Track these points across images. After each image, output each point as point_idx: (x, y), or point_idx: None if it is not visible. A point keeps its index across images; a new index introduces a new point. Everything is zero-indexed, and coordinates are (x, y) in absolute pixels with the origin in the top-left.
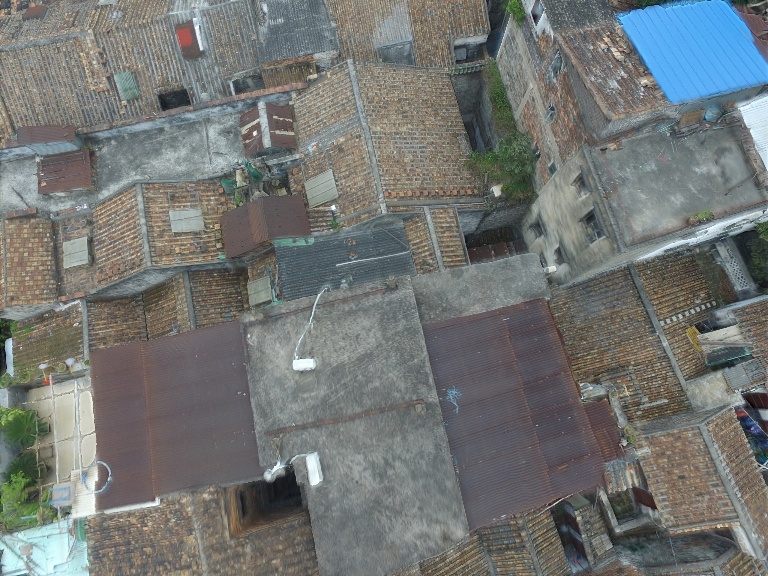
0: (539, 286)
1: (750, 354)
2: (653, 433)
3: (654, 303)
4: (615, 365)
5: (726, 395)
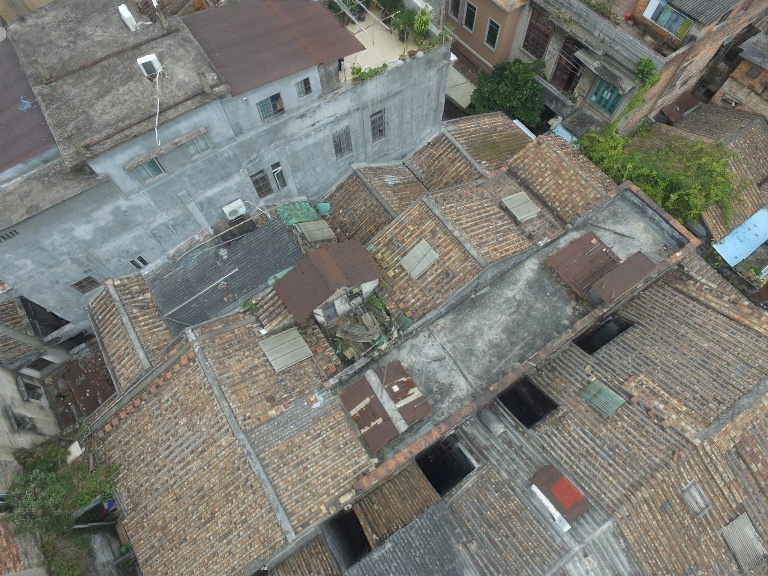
0: None
1: None
2: None
3: None
4: None
5: None
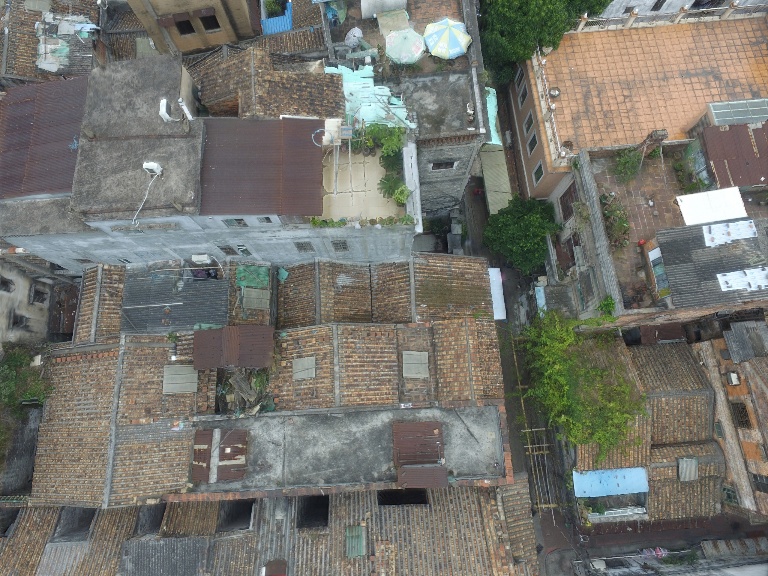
0: None
1: None
2: None
3: None
4: None
5: None
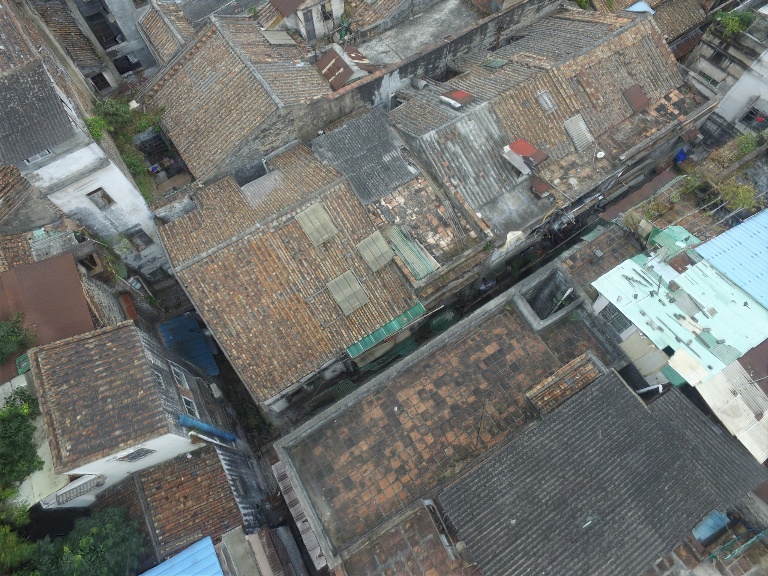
0: None
1: None
2: None
3: None
4: None
5: None
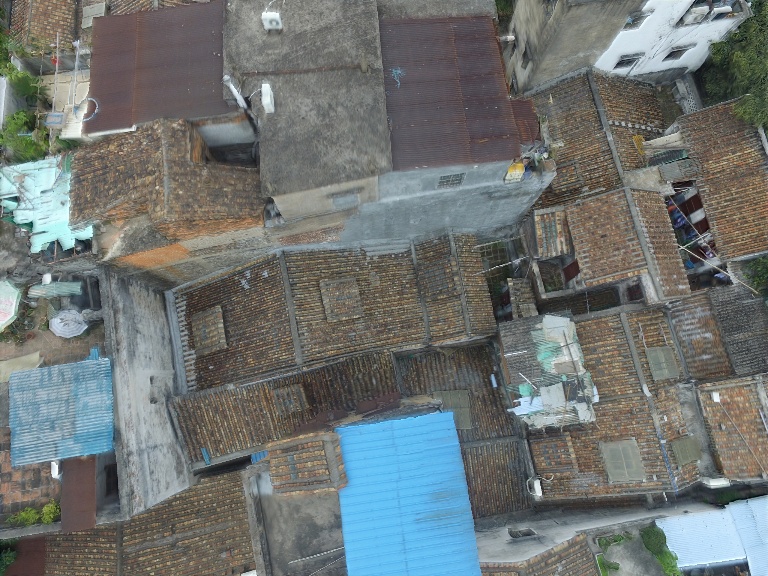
0: (489, 11)
1: (687, 156)
2: (584, 200)
3: (606, 108)
4: (563, 160)
5: (658, 185)
